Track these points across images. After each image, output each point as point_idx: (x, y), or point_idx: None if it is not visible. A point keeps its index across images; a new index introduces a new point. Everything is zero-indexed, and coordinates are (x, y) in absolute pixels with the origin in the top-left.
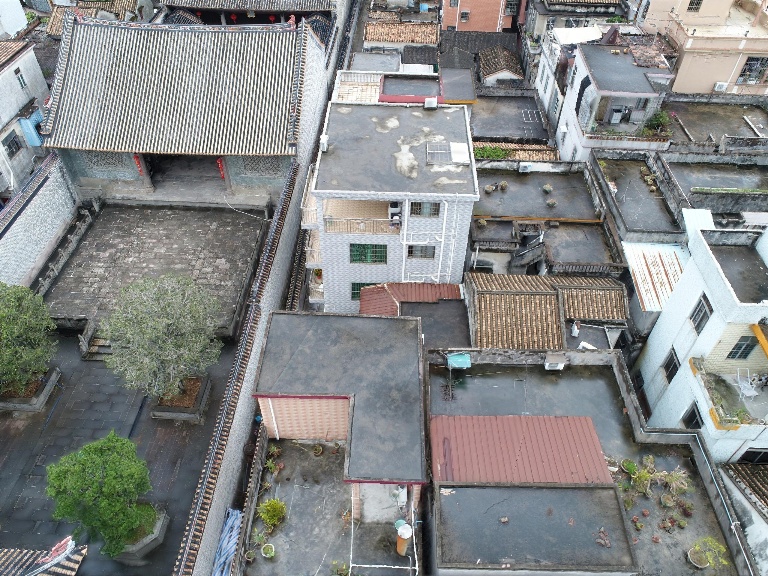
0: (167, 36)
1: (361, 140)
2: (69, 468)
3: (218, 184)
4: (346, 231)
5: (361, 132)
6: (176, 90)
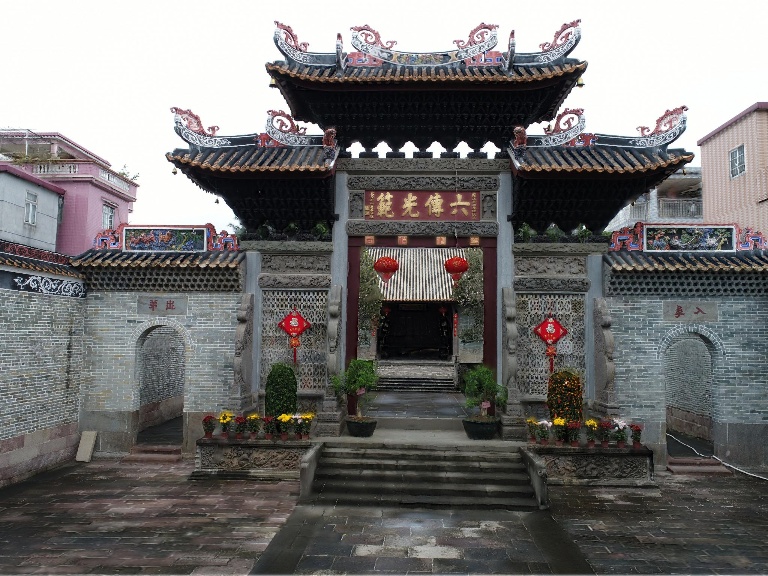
0: (399, 251)
1: None
2: None
3: (437, 361)
4: (678, 215)
5: None
6: (413, 272)
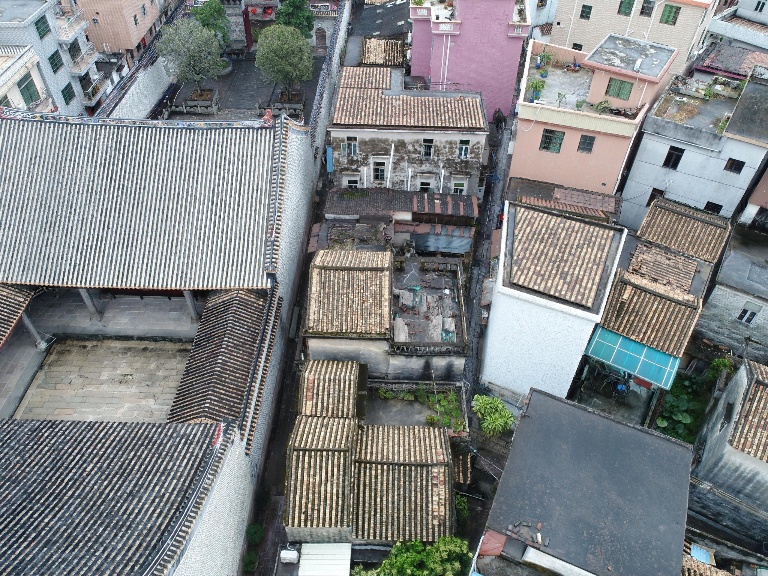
0: None
1: (21, 4)
2: (213, 1)
3: None
4: None
5: (17, 8)
6: None
